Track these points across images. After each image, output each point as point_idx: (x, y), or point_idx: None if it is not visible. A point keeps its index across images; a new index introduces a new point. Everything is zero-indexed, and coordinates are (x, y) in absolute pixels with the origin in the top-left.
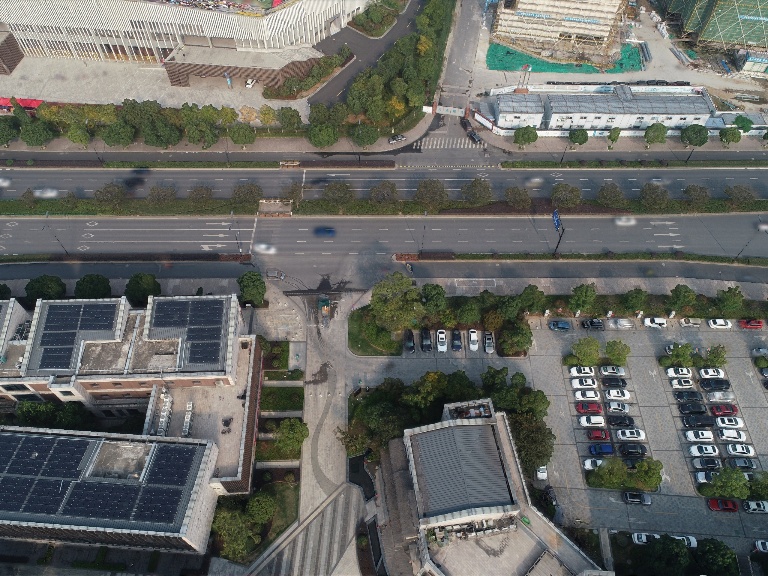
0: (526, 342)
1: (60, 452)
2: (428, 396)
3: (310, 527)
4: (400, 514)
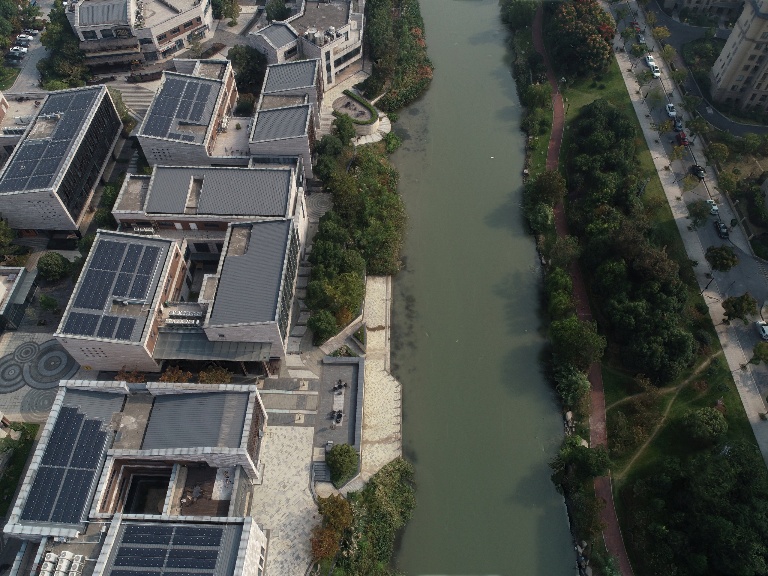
0: (37, 9)
1: (25, 156)
2: (57, 26)
3: (123, 100)
4: (124, 44)
